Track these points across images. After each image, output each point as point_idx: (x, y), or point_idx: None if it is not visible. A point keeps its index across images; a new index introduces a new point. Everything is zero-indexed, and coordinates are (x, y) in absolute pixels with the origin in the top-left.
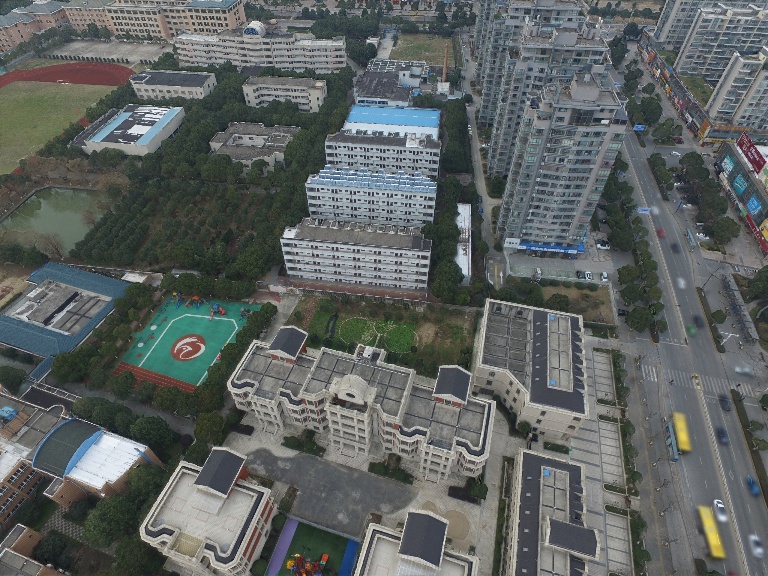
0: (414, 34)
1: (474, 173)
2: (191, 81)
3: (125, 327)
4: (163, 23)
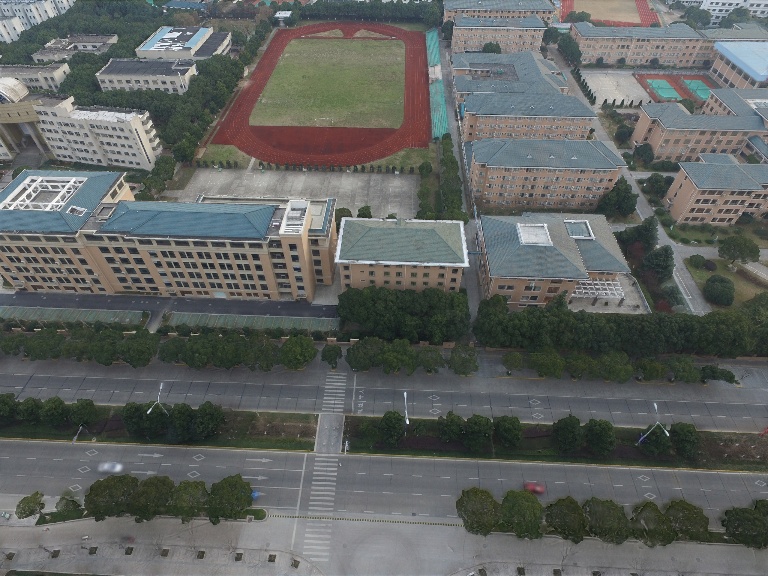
0: None
1: None
2: (125, 67)
3: None
4: None
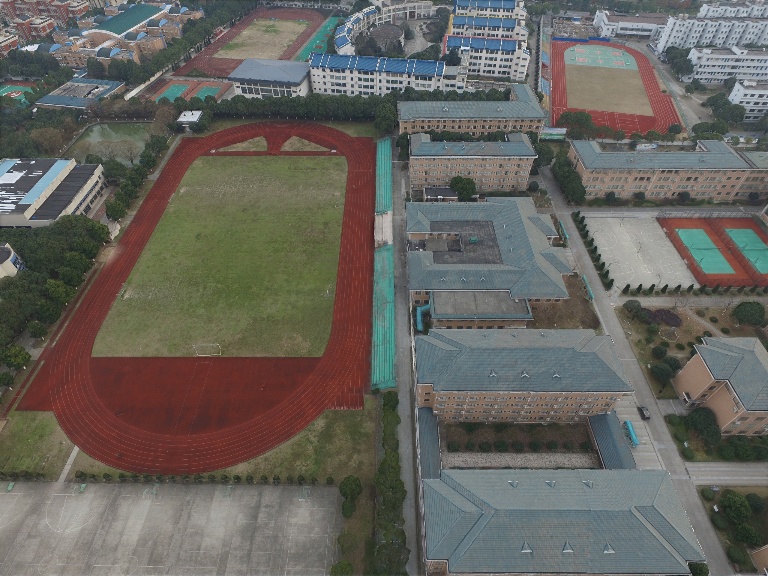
0: None
1: None
2: None
3: (36, 82)
4: None
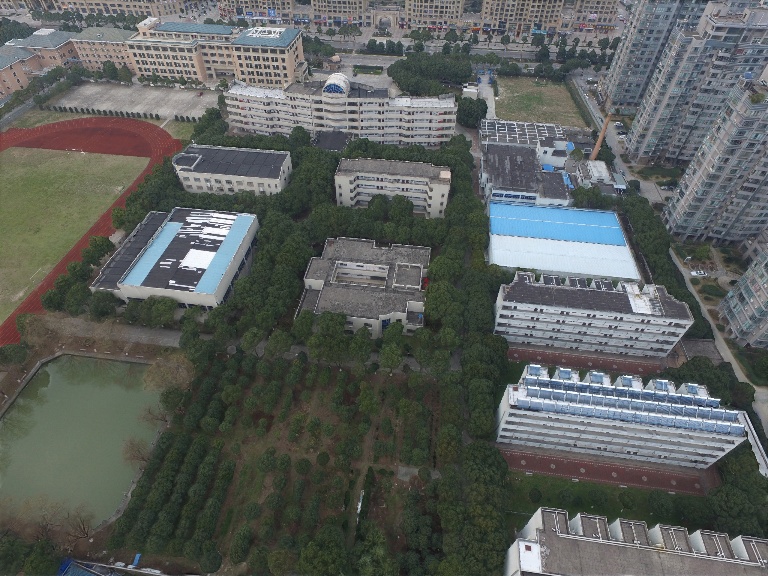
0: (514, 77)
1: None
2: (259, 166)
3: None
4: (200, 62)
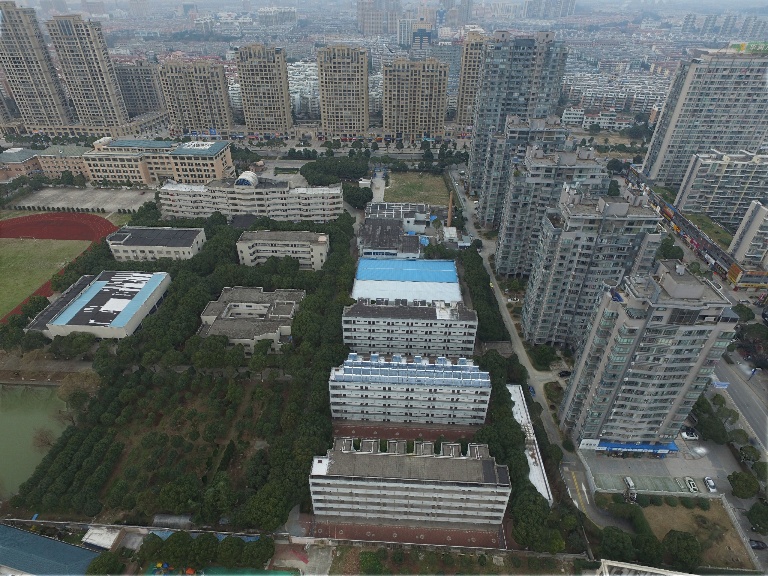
0: (404, 172)
1: (510, 338)
2: (177, 239)
3: None
4: (144, 169)
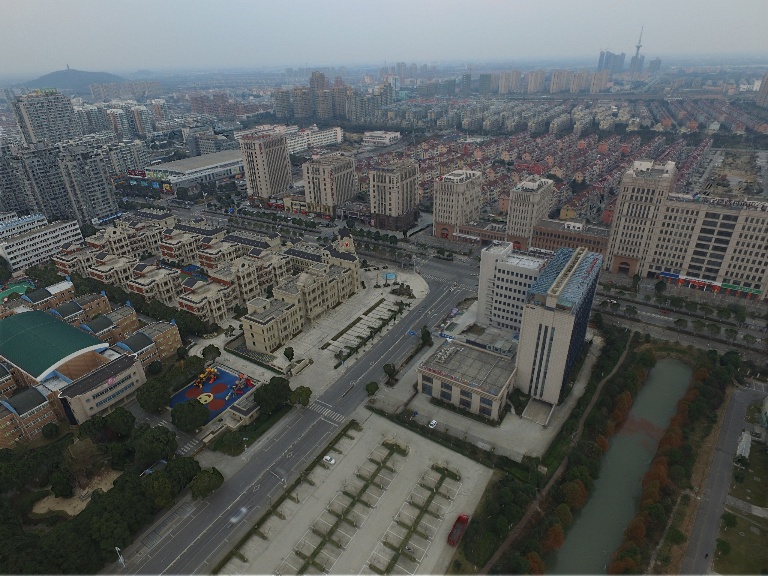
0: None
1: None
2: None
3: None
4: None
